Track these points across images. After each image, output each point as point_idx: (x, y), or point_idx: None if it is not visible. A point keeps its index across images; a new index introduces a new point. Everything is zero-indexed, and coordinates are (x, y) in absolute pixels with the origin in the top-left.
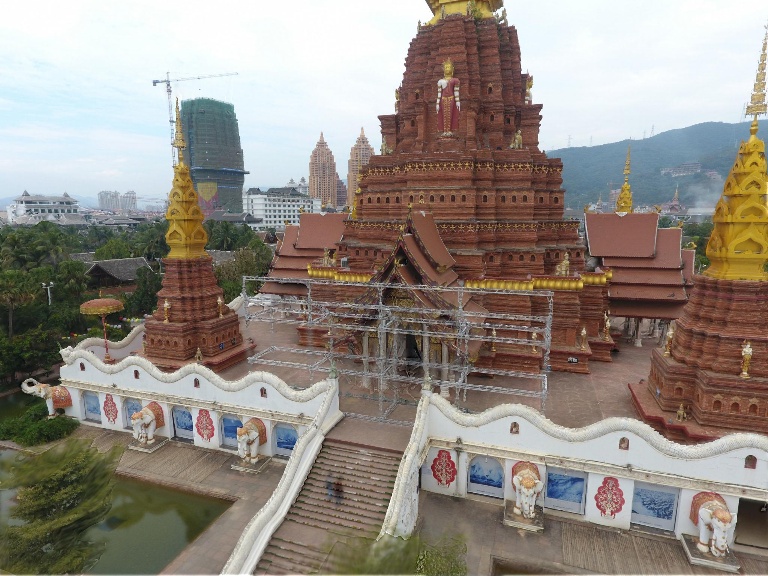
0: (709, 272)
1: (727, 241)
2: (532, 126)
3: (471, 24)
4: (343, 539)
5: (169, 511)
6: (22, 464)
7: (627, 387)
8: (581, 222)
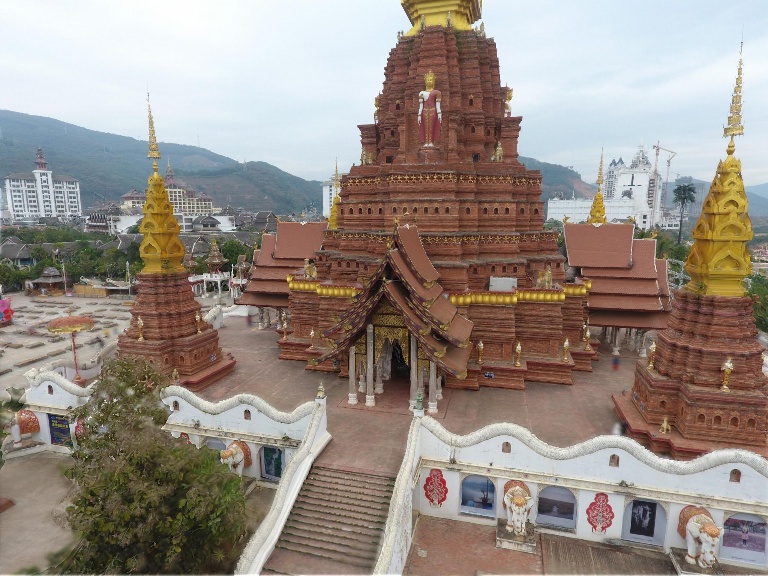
0: None
1: None
2: None
3: None
4: None
5: None
6: None
7: None
8: None
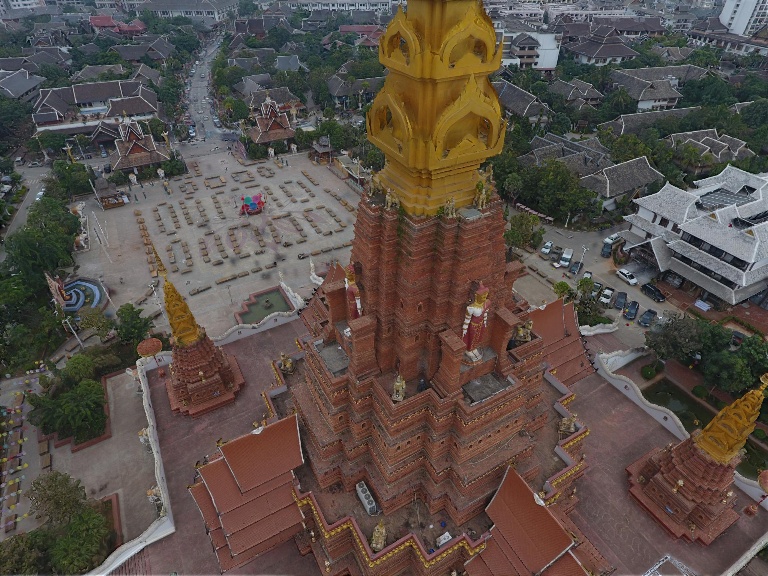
0: (709, 452)
1: (731, 444)
2: (510, 283)
3: (487, 220)
4: None
5: None
6: None
7: (613, 478)
8: (200, 21)
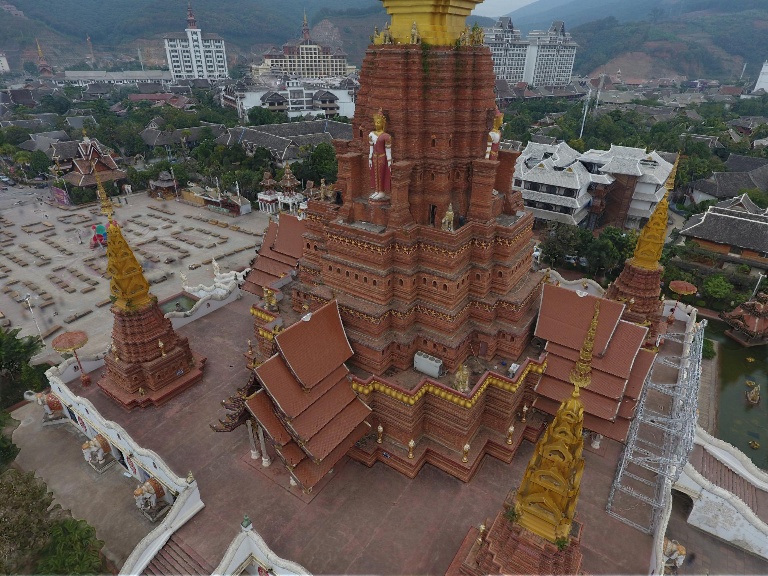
0: (644, 266)
1: None
2: None
3: None
4: (761, 504)
5: None
6: None
7: None
8: None
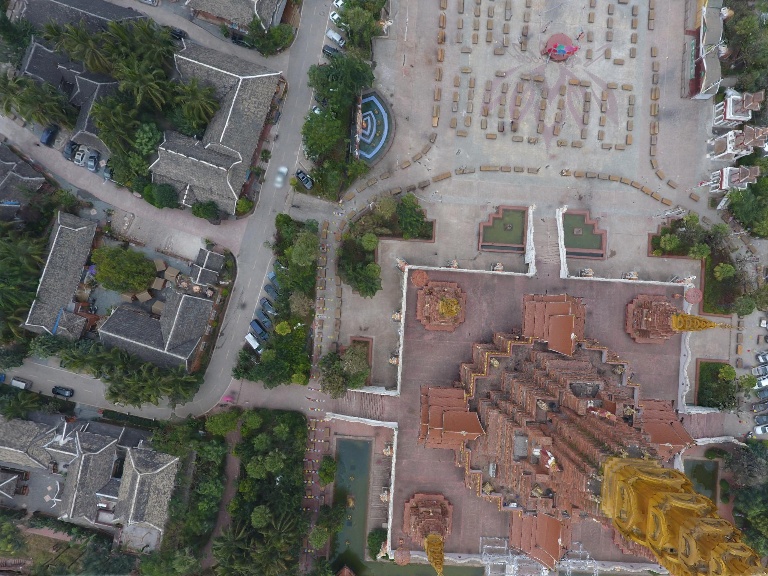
0: None
1: None
2: None
3: None
4: None
5: (466, 573)
6: (398, 565)
7: None
8: None
